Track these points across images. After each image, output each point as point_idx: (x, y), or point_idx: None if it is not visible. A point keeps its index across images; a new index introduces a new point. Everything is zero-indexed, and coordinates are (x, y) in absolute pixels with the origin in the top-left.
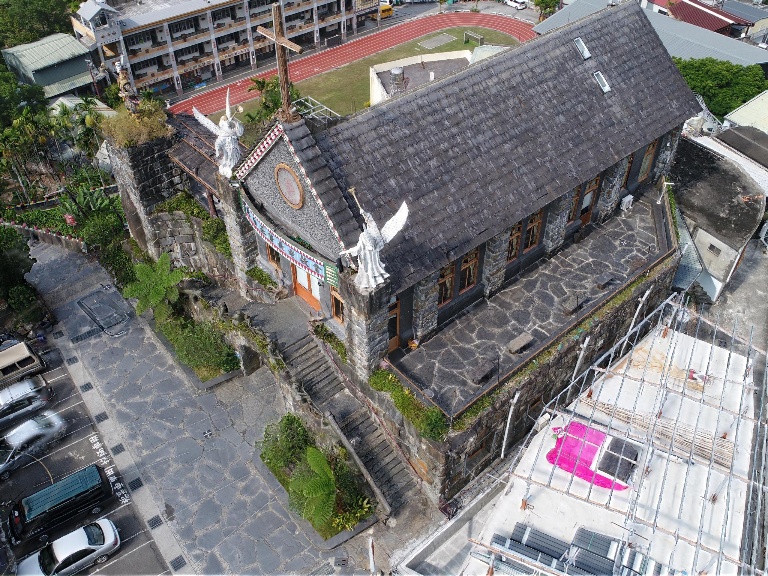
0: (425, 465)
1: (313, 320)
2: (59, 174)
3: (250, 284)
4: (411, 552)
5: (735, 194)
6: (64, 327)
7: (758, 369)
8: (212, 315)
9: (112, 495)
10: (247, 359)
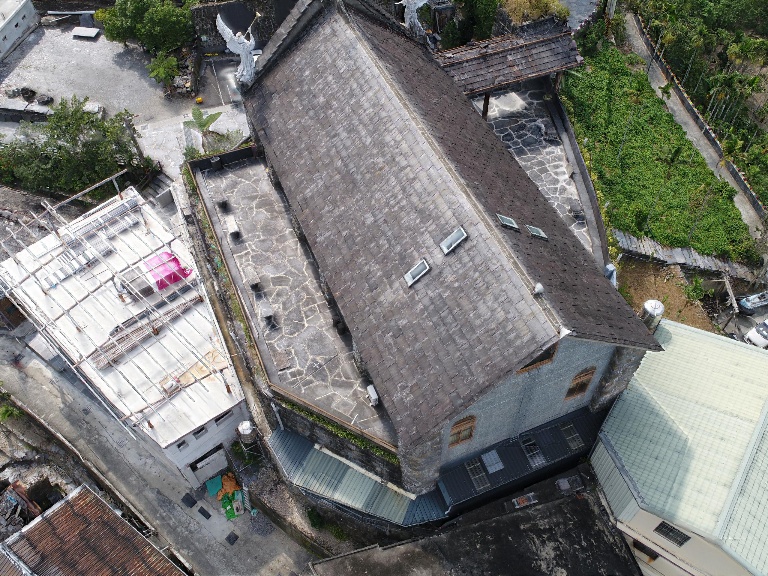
0: None
1: None
2: None
3: None
4: None
5: None
6: None
7: None
8: None
9: None
10: None
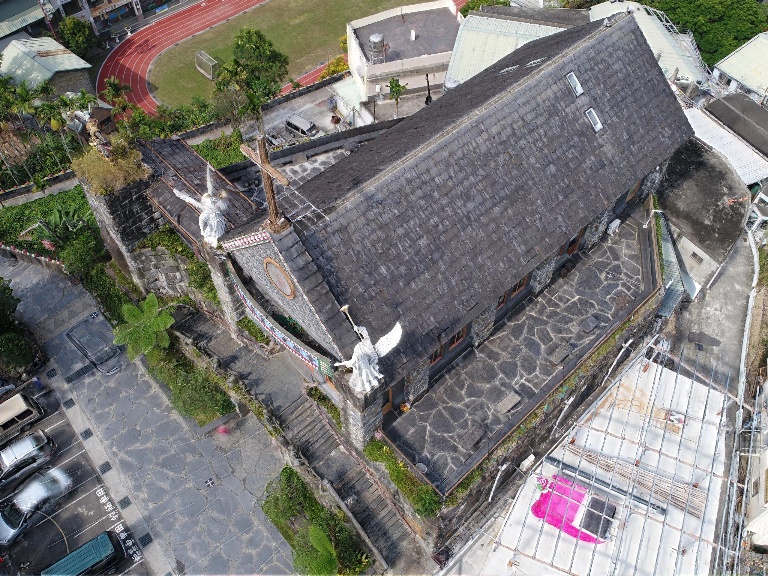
0: (419, 527)
1: (307, 385)
2: (24, 143)
3: (241, 332)
4: None
5: (721, 196)
6: (56, 365)
7: (731, 374)
8: (205, 363)
9: (125, 558)
10: (242, 404)
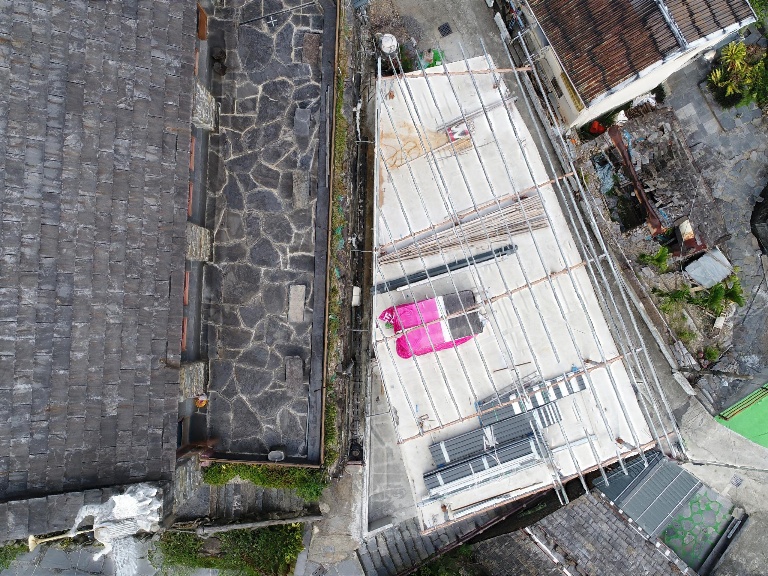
0: None
1: None
2: None
3: None
4: (362, 519)
5: None
6: None
7: None
8: None
9: None
10: None
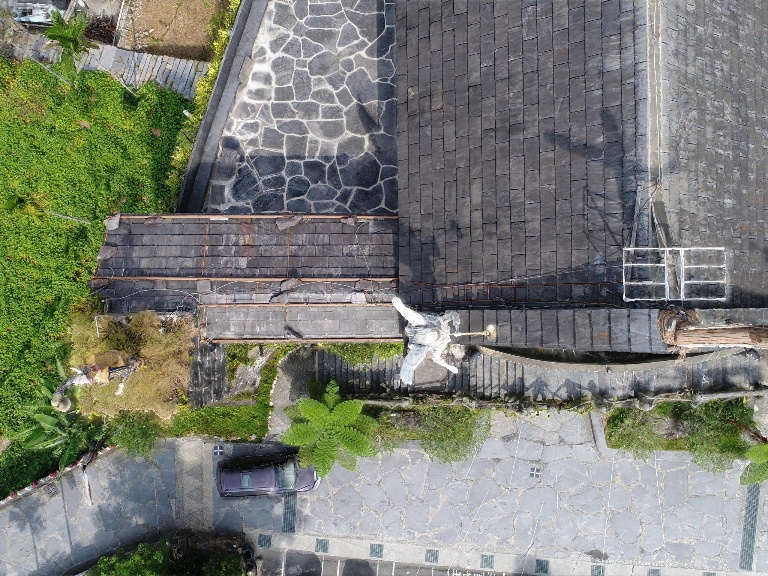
0: None
1: None
2: None
3: None
4: None
5: None
6: (256, 530)
7: None
8: None
9: None
10: None
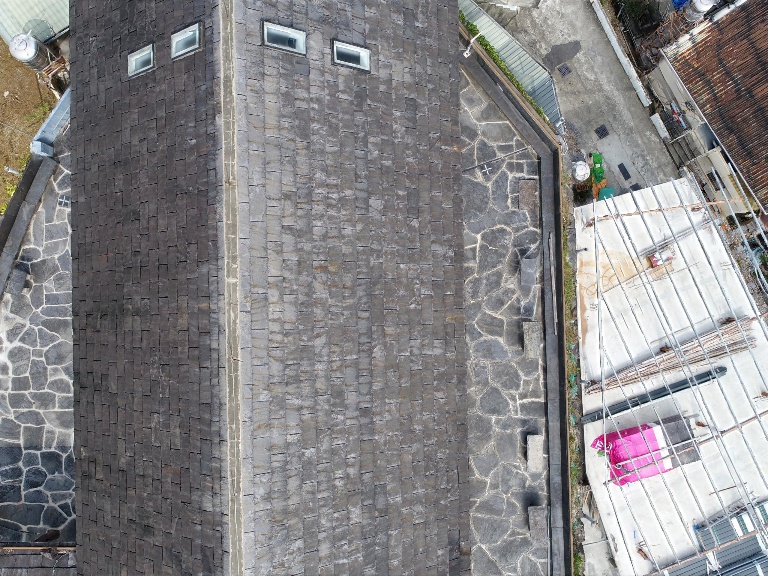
0: None
1: None
2: None
3: None
4: None
5: None
6: None
7: (615, 75)
8: None
9: None
10: None
